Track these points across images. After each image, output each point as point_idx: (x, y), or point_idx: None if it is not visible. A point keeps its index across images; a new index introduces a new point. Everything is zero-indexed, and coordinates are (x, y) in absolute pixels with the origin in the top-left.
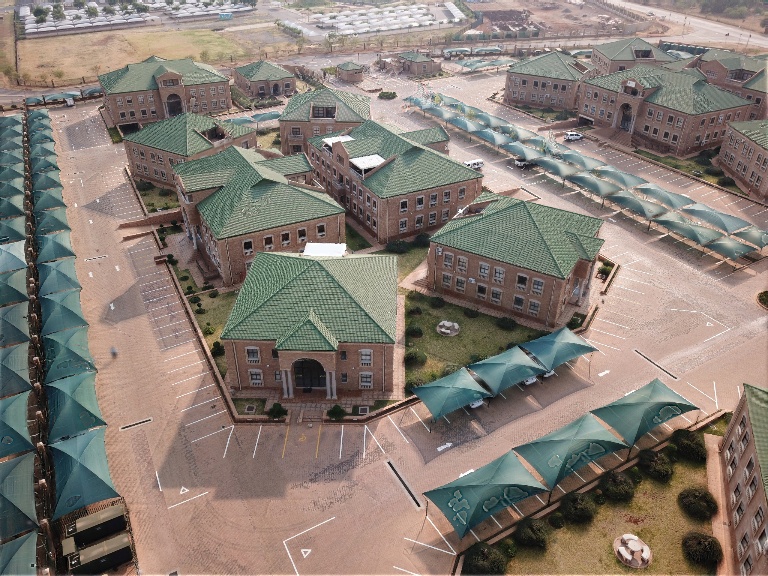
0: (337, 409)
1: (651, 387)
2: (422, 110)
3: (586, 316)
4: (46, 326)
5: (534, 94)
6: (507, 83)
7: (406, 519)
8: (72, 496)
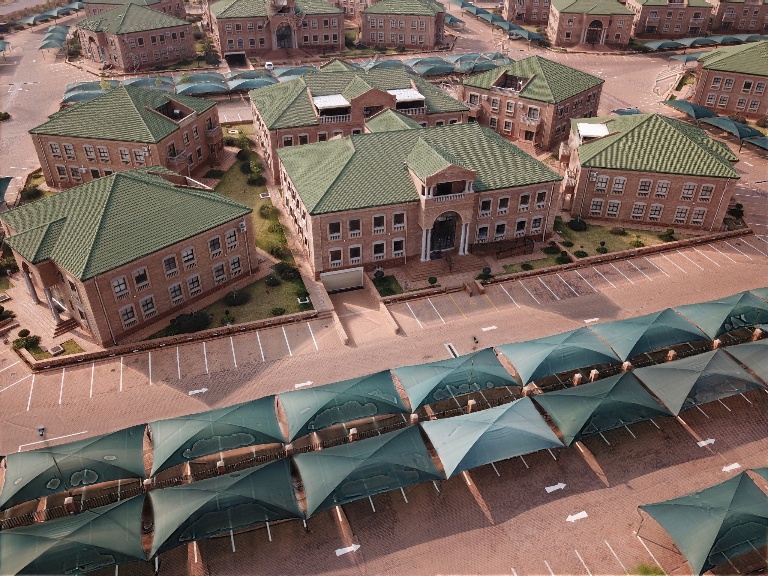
0: None
1: (674, 101)
2: None
3: None
4: (697, 333)
5: (155, 52)
6: (122, 49)
7: None
8: None
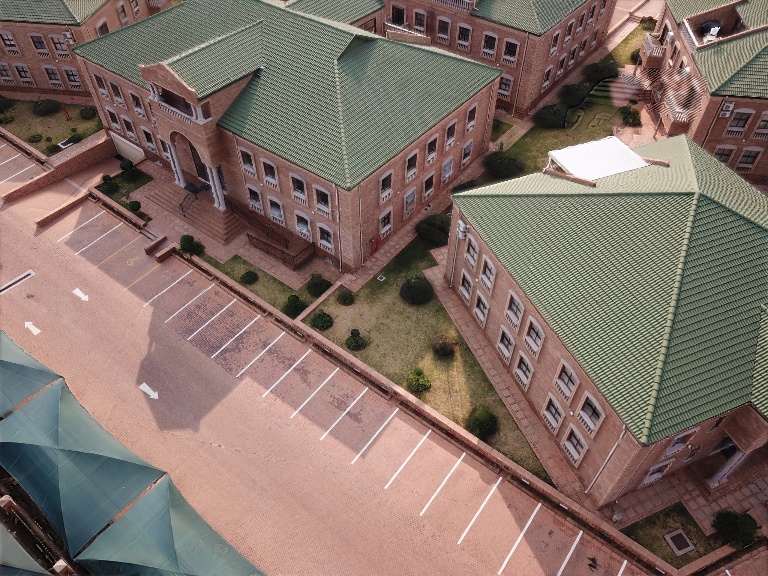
0: None
1: None
2: None
3: None
4: (70, 524)
5: None
6: None
7: None
8: None
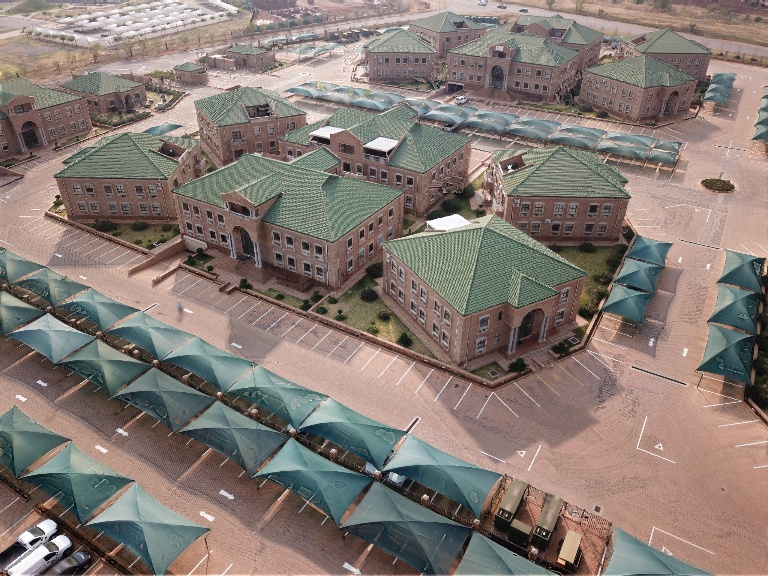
0: (564, 345)
1: (734, 254)
2: (314, 98)
3: (628, 227)
4: (220, 380)
5: (397, 70)
6: (370, 63)
7: (689, 396)
8: None
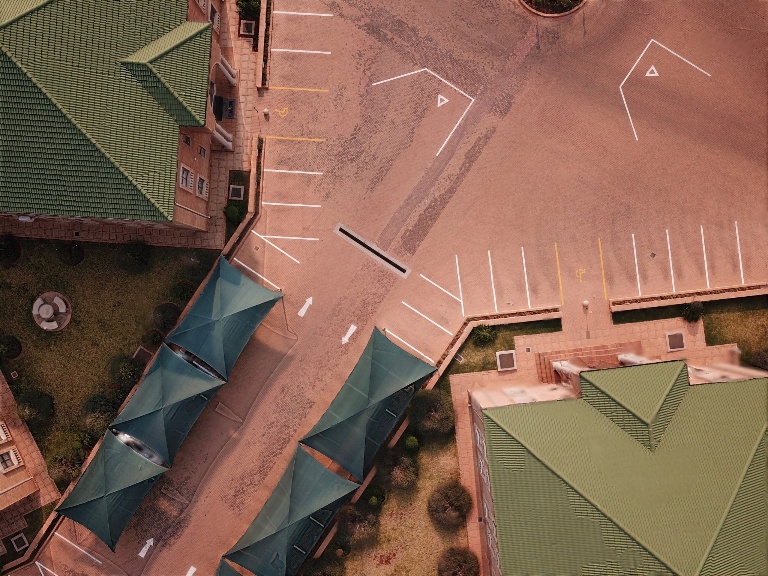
0: None
1: (368, 368)
2: None
3: (249, 177)
4: None
5: None
6: None
7: None
8: None
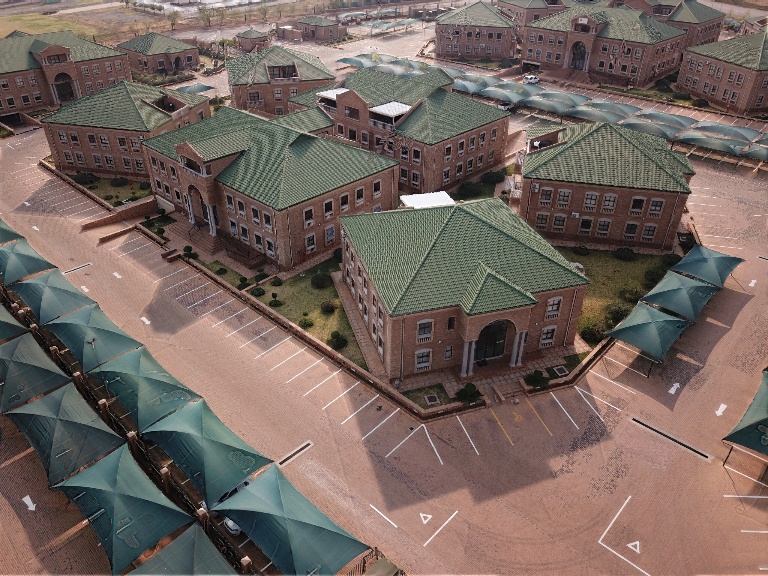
0: (541, 374)
1: None
2: None
3: (691, 234)
4: (86, 358)
5: (468, 46)
6: (438, 36)
7: (707, 475)
8: (308, 567)
